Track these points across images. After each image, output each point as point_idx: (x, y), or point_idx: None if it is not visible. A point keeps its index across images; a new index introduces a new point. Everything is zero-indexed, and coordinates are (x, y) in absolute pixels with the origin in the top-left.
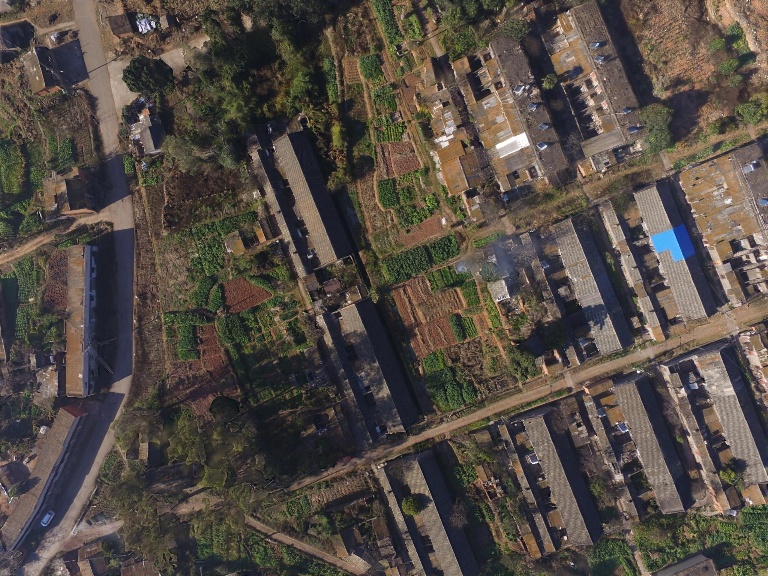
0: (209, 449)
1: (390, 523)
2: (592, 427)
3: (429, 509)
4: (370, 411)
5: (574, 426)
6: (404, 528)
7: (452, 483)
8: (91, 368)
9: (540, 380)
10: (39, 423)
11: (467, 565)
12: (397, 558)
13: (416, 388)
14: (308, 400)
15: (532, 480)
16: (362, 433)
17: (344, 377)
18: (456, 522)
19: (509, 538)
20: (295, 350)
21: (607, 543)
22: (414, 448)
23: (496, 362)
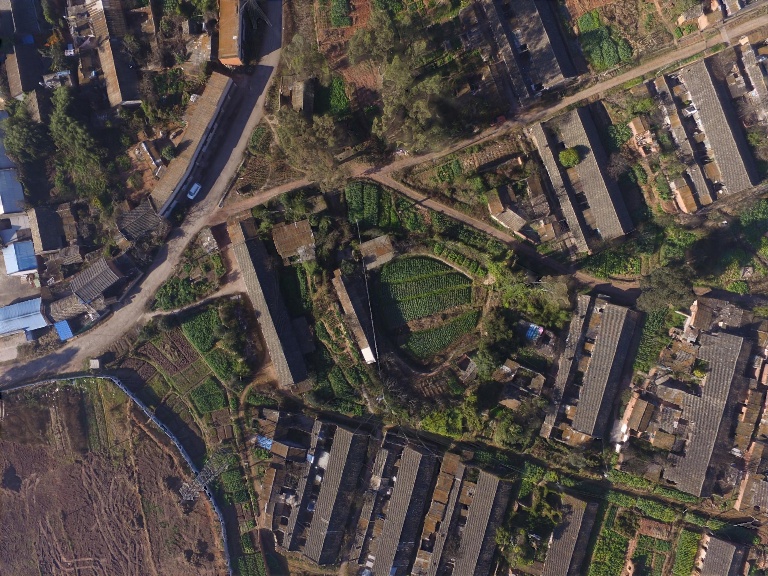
0: (360, 115)
1: (542, 185)
2: (748, 81)
3: (586, 160)
4: (525, 69)
5: (731, 76)
6: (559, 183)
7: (605, 143)
8: (242, 36)
9: (696, 36)
10: (190, 90)
11: (623, 218)
12: (551, 215)
13: (571, 48)
14: (461, 64)
15: (689, 132)
16: (515, 96)
17: (501, 32)
18: (614, 170)
19: (662, 197)
20: (447, 17)
21: (760, 202)
22: (568, 108)
23: (652, 18)
